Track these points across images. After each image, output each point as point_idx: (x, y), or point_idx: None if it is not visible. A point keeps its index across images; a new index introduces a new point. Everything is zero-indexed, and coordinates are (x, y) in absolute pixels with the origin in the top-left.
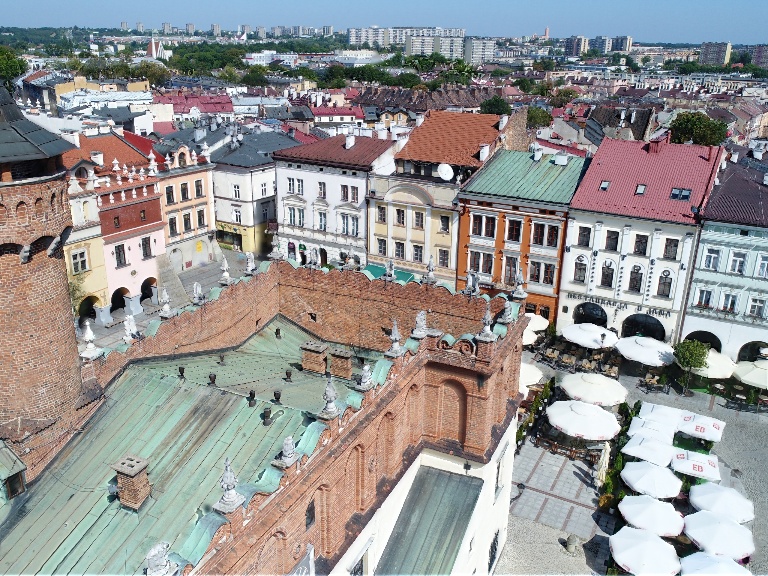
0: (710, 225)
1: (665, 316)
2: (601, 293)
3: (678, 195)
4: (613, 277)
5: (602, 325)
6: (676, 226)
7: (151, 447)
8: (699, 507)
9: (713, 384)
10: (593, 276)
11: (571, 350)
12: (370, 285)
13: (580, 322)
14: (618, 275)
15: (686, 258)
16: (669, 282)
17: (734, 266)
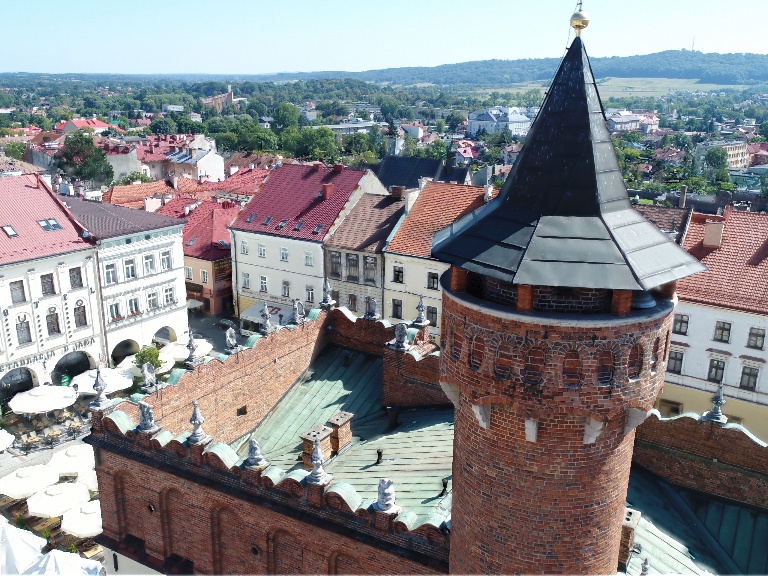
0: (103, 243)
1: (90, 344)
2: (23, 353)
3: (49, 226)
4: (31, 330)
5: (35, 386)
6: (77, 254)
7: None
8: None
9: (161, 377)
10: (10, 339)
11: (35, 425)
12: (223, 368)
13: (2, 399)
14: (36, 325)
15: (92, 281)
16: (82, 311)
17: (128, 273)
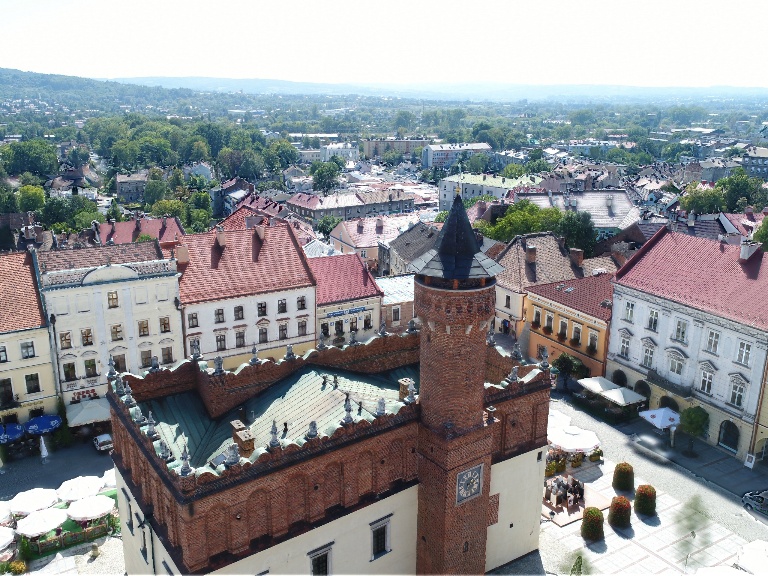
0: None
1: None
2: None
3: None
4: None
5: None
6: None
7: (392, 405)
8: (6, 516)
9: None
10: None
11: None
12: None
13: None
14: None
15: None
16: None
17: None
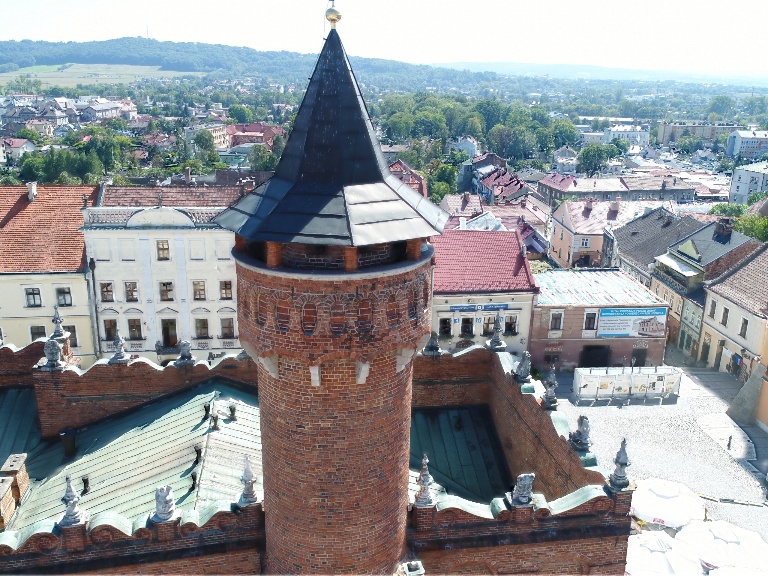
0: None
1: None
2: None
3: None
4: None
5: None
6: None
7: None
8: None
9: None
10: None
11: None
12: None
13: None
14: None
15: None
16: None
17: None
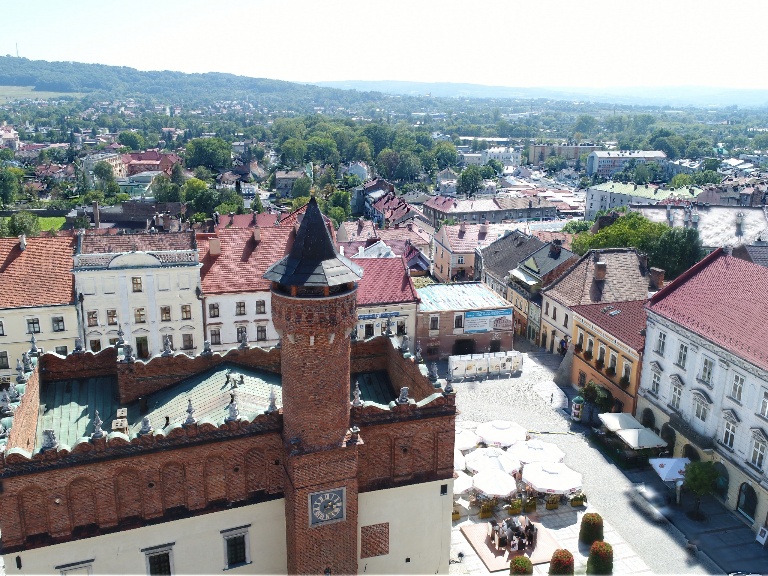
0: None
1: None
2: None
3: None
4: None
5: None
6: None
7: None
8: None
9: None
10: None
11: None
12: None
13: None
14: None
15: None
16: None
17: None
